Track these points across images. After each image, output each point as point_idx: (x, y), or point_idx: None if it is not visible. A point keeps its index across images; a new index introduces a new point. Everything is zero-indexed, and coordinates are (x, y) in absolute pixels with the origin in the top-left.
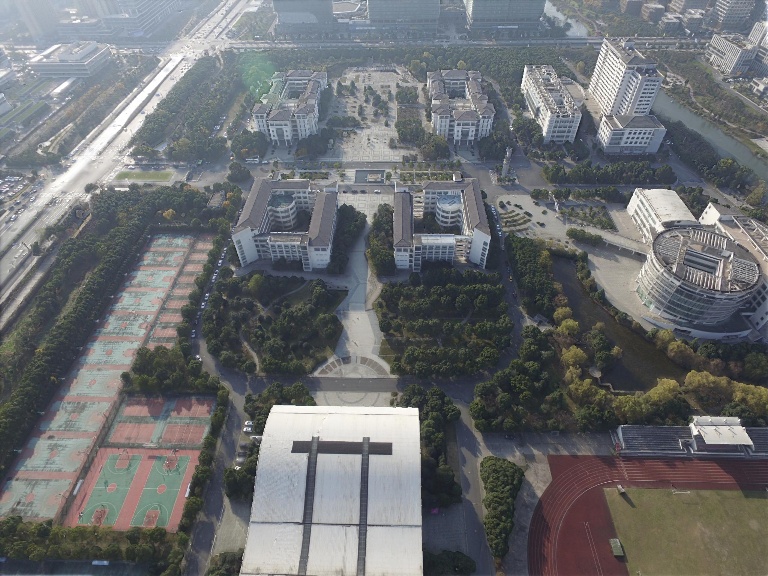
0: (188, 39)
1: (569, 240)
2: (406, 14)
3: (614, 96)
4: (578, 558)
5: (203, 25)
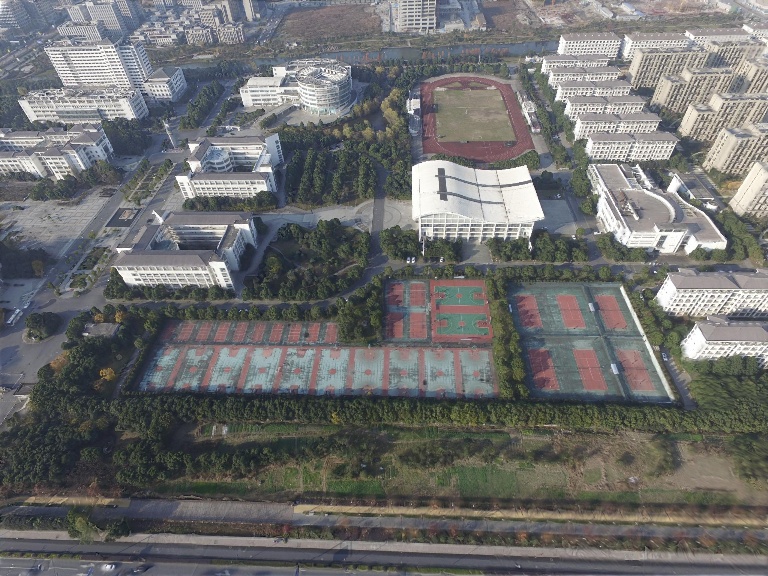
0: None
1: (266, 129)
2: None
3: (124, 72)
4: (470, 151)
5: None
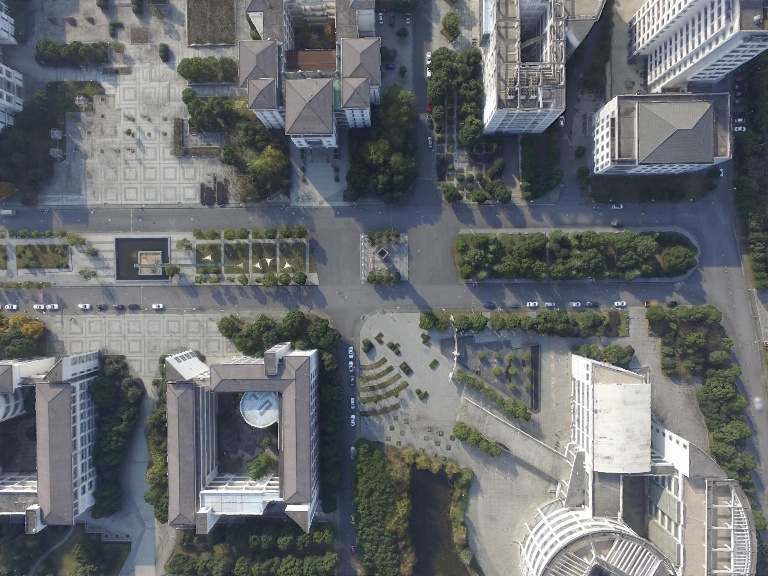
0: None
1: None
2: None
3: (667, 20)
4: None
5: None
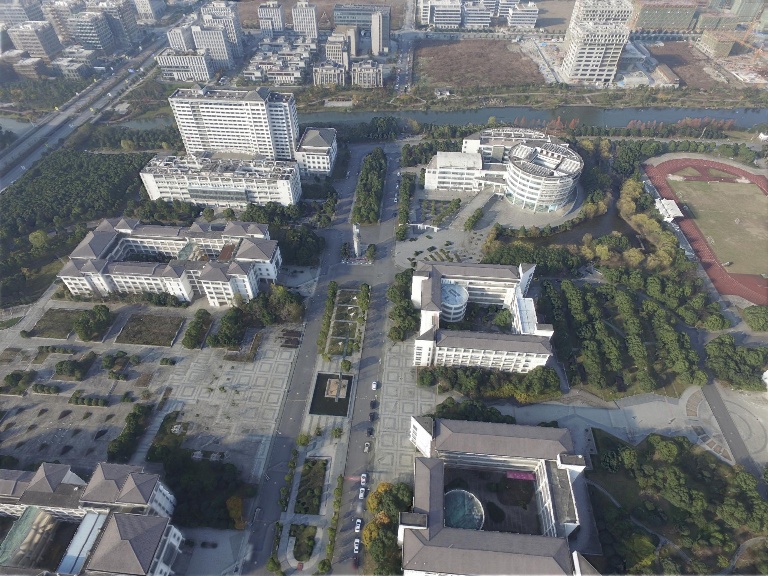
0: None
1: (472, 231)
2: None
3: (269, 135)
4: None
5: None
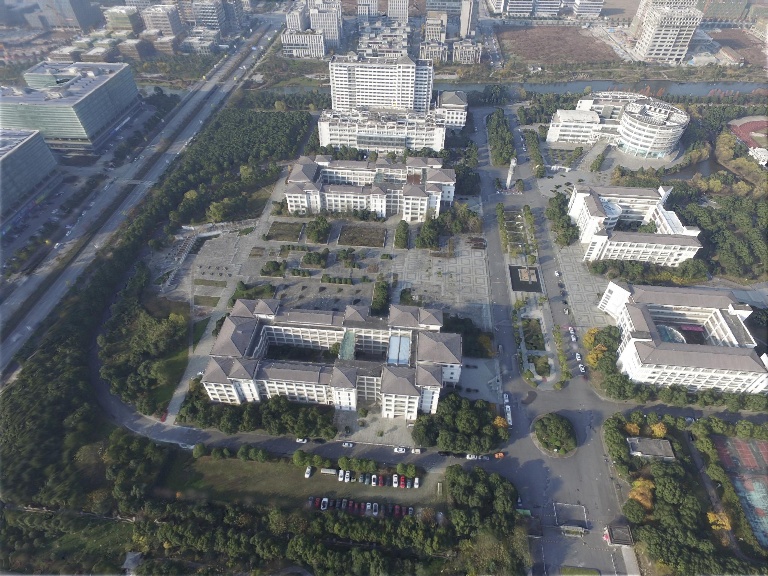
0: None
1: (597, 172)
2: (18, 188)
3: (413, 94)
4: None
5: None
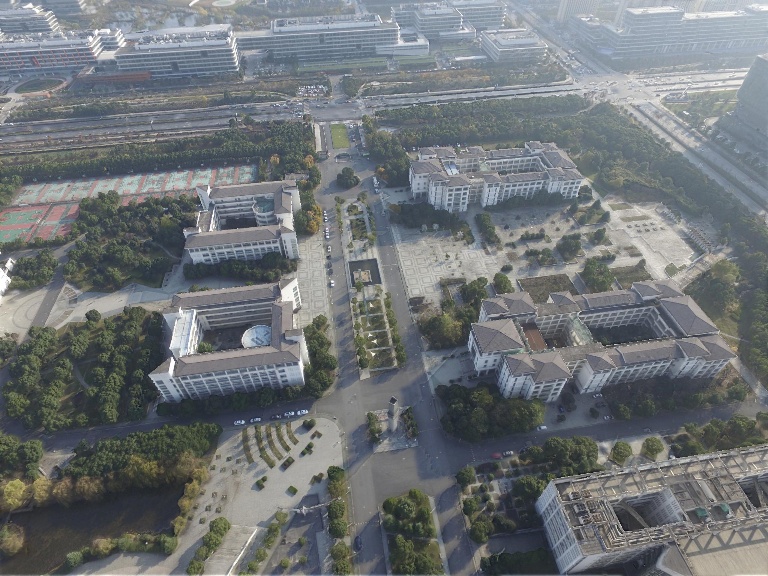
0: (633, 78)
1: None
2: None
3: None
4: None
5: (684, 75)
